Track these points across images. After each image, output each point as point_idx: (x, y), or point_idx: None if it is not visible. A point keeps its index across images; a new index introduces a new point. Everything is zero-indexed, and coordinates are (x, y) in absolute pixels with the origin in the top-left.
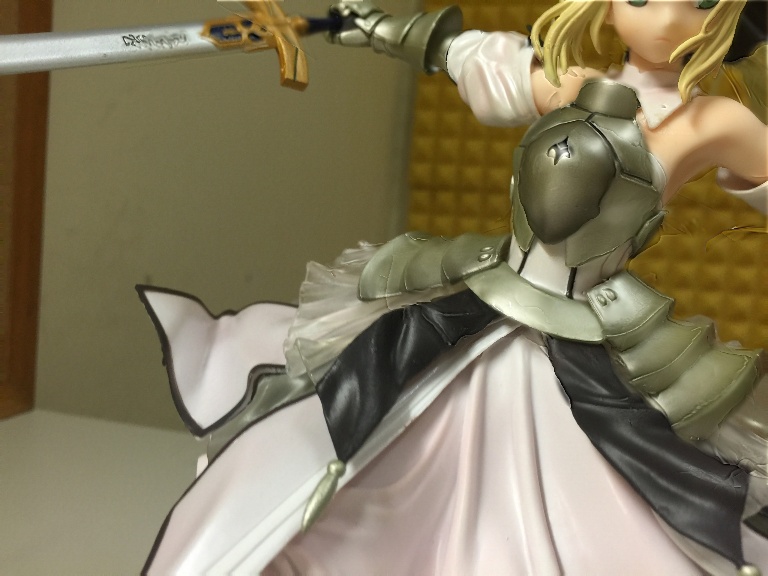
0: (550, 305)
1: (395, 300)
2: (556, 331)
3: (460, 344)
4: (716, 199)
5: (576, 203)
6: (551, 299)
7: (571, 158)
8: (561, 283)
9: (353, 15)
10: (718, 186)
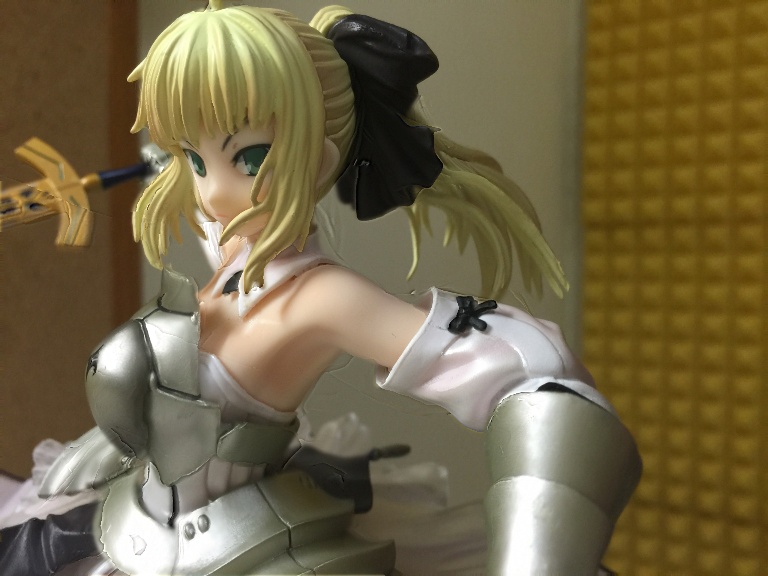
0: (151, 531)
1: (41, 508)
2: (130, 571)
3: (90, 565)
4: (376, 388)
5: (115, 424)
6: (152, 523)
7: (115, 368)
8: (165, 503)
9: (158, 164)
10: (374, 372)
